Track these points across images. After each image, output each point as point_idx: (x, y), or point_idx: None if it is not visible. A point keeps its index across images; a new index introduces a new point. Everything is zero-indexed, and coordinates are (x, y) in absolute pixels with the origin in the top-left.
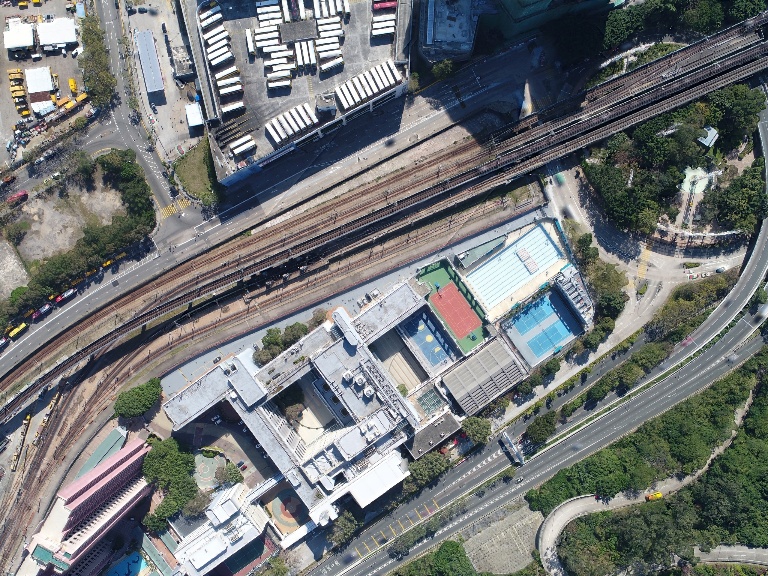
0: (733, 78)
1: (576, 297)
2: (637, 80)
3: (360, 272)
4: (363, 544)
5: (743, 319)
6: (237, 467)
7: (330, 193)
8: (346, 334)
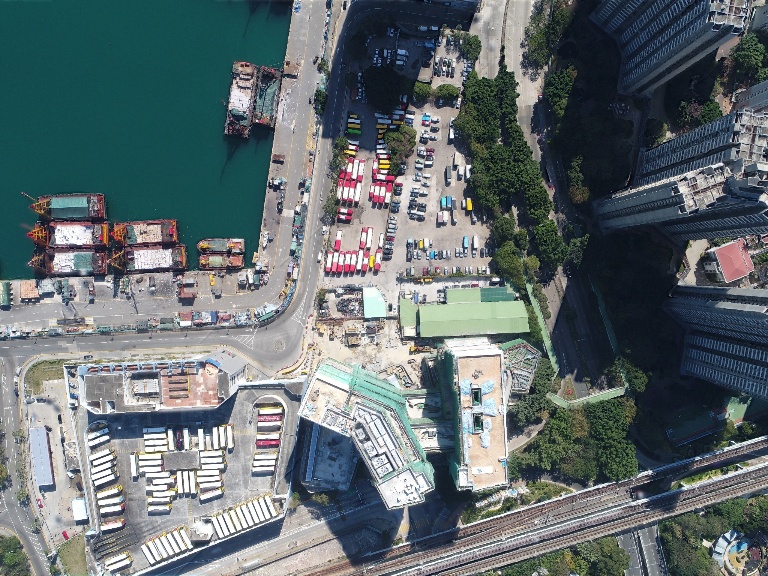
0: (602, 532)
1: None
2: (509, 523)
3: None
4: None
5: None
6: None
7: None
8: None
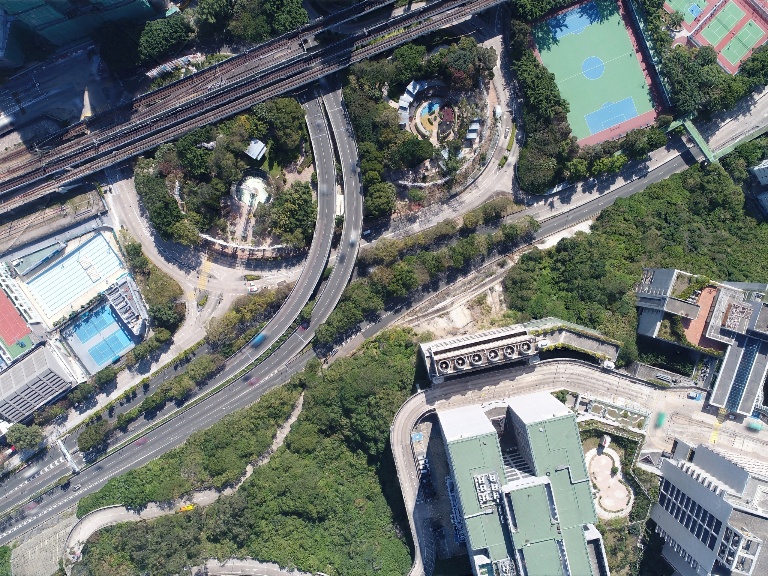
0: (278, 91)
1: None
2: (183, 91)
3: None
4: None
5: (296, 333)
6: None
7: None
8: None
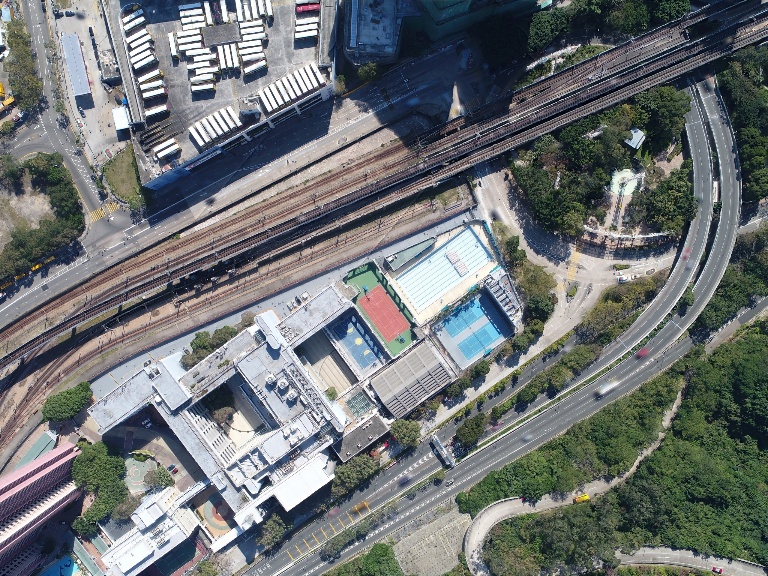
0: (659, 80)
1: (504, 299)
2: (563, 82)
3: (290, 275)
4: (295, 547)
5: (672, 321)
6: (168, 470)
7: (259, 196)
8: (268, 338)
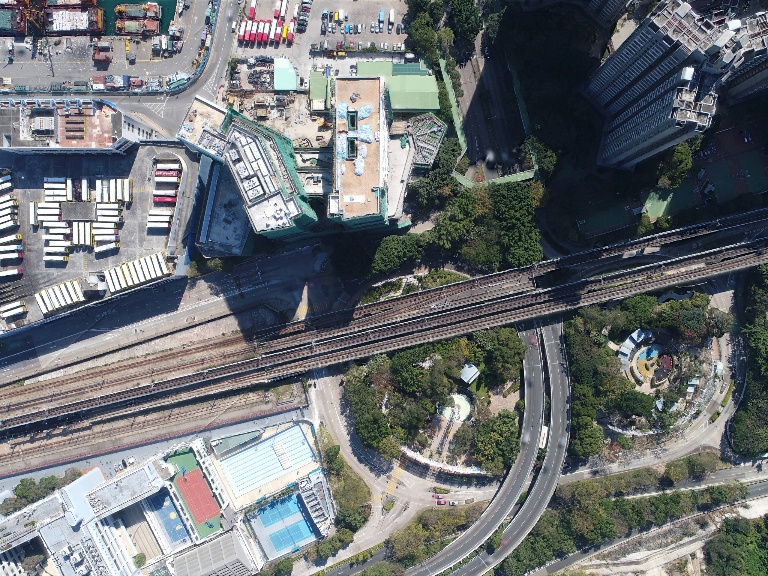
0: (501, 321)
1: (315, 505)
2: (406, 306)
3: (121, 438)
4: None
5: (479, 556)
6: None
7: (102, 359)
8: (67, 514)
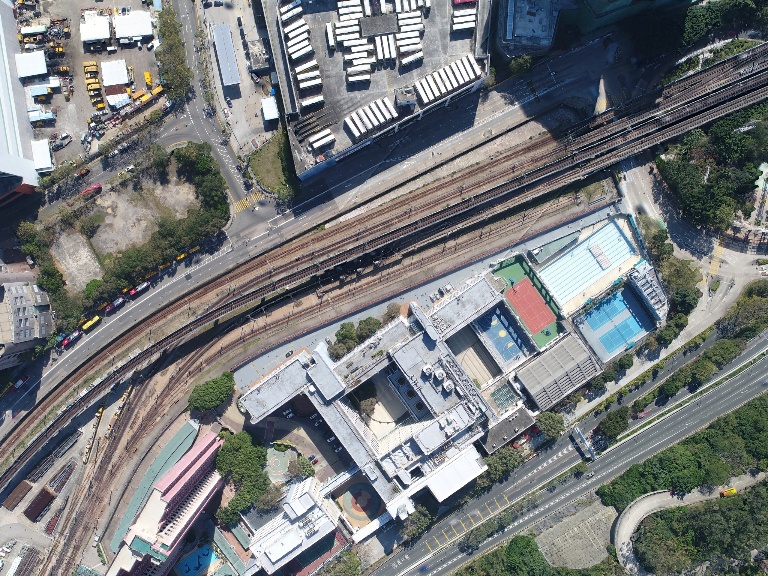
0: None
1: (650, 293)
2: (714, 76)
3: (433, 267)
4: (433, 538)
5: None
6: (309, 461)
7: (404, 188)
8: (427, 328)
